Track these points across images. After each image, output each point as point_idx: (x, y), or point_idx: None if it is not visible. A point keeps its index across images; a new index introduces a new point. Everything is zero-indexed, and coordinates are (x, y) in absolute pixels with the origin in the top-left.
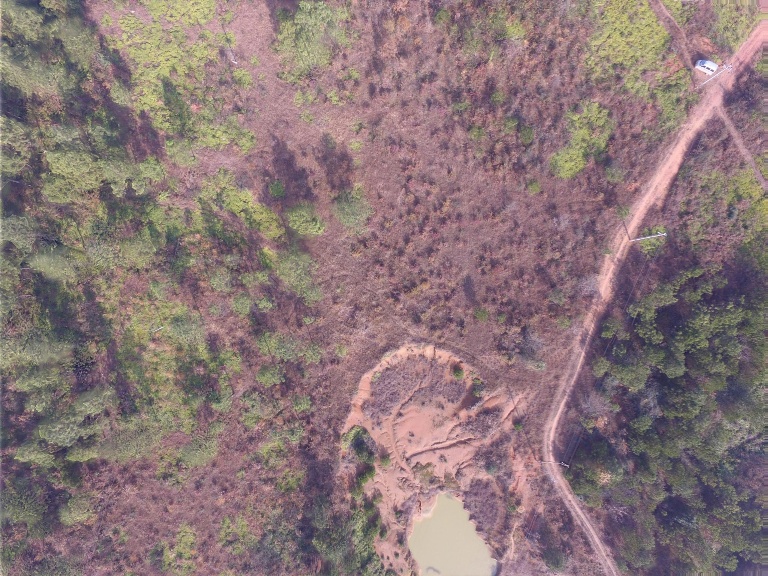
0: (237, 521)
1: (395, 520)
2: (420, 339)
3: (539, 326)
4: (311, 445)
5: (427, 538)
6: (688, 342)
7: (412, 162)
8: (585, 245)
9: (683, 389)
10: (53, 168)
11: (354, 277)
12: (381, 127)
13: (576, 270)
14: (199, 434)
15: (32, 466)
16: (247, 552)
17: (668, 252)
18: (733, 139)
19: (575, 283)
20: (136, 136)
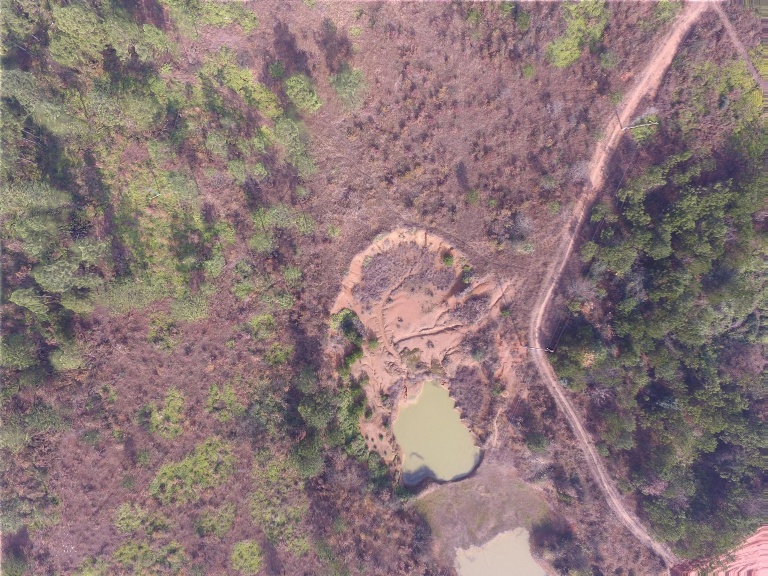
0: (225, 389)
1: (381, 404)
2: (412, 224)
3: (529, 213)
4: (300, 320)
5: (412, 424)
6: (675, 224)
7: (410, 49)
8: (577, 133)
9: (668, 269)
10: (59, 24)
11: (349, 160)
12: (381, 13)
13: (568, 158)
14: (191, 301)
15: (27, 323)
16: (233, 419)
17: (659, 140)
18: (727, 30)
19: (566, 171)
20: (141, 9)
